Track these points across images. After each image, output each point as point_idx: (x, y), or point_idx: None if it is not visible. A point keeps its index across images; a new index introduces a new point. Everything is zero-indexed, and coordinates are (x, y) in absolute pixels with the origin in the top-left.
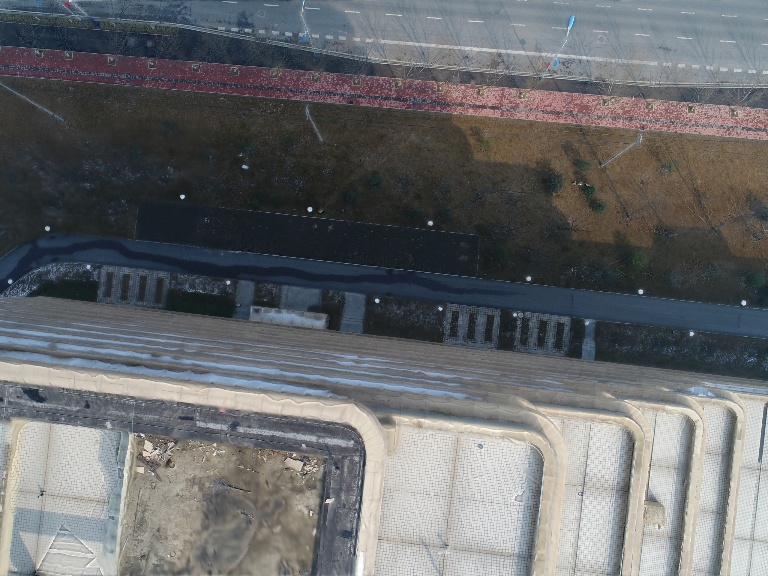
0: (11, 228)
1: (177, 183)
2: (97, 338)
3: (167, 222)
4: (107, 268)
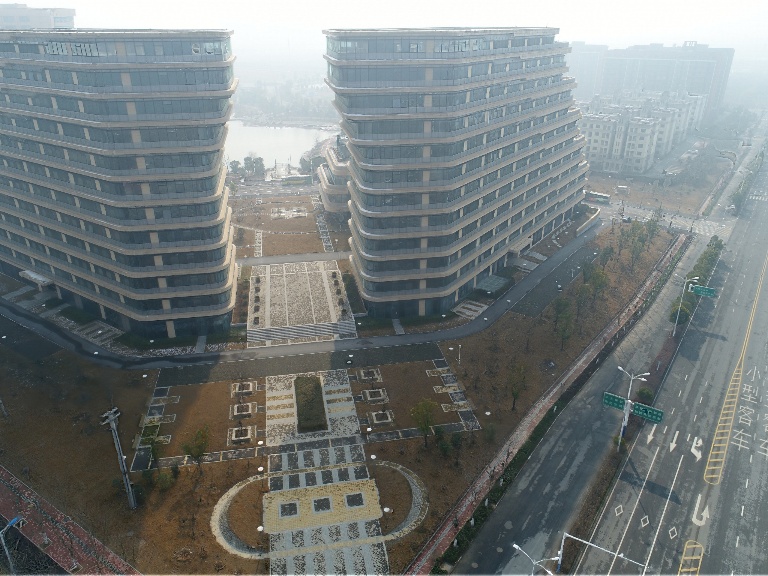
0: (126, 379)
1: (0, 358)
2: (12, 110)
3: (36, 348)
4: (99, 344)
